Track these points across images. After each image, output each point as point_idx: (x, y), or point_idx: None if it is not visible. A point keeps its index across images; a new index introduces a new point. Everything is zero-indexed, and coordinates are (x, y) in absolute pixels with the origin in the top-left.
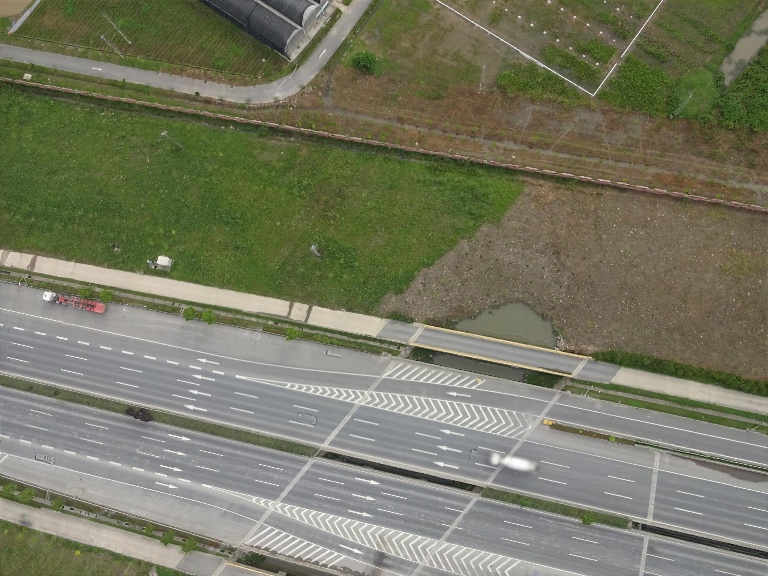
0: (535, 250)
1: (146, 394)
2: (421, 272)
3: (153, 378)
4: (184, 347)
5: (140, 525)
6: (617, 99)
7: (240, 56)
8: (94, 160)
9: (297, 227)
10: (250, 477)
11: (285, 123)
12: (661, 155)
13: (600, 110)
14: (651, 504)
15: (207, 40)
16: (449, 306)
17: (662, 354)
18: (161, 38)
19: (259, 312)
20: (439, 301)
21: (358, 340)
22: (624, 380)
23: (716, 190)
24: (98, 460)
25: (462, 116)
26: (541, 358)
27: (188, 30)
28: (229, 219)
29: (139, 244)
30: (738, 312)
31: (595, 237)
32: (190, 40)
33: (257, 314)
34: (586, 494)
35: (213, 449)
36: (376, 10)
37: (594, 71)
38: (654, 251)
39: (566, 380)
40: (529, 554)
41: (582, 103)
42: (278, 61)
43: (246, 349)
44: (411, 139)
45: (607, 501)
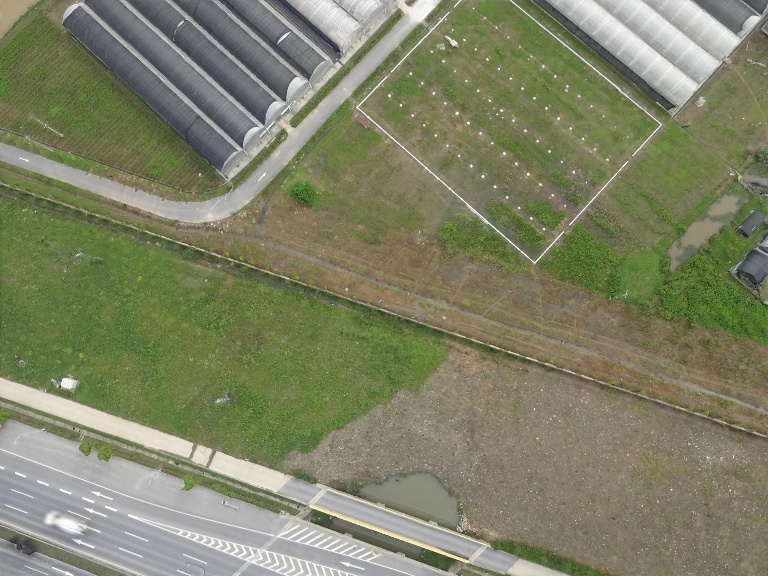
0: (450, 425)
1: (34, 521)
2: (330, 433)
3: (43, 505)
4: (79, 477)
5: None
6: (558, 271)
7: (176, 167)
8: (8, 264)
9: (210, 366)
10: None
11: (212, 250)
12: (594, 337)
13: (539, 280)
14: None
15: (144, 144)
16: (355, 469)
17: (562, 551)
18: (95, 135)
19: (161, 450)
20: (345, 464)
21: (258, 493)
22: (520, 572)
23: (644, 382)
24: None
25: (397, 266)
26: (440, 538)
27: (125, 130)
28: (141, 348)
29: (45, 360)
30: (644, 518)
31: (512, 420)
32: (126, 141)
33: (158, 452)
34: None
35: None
36: (324, 137)
37: (539, 237)
38: (570, 443)
39: (463, 563)
40: None
41: (522, 270)
42: (215, 178)
43: (142, 487)
44: (341, 283)
45: None
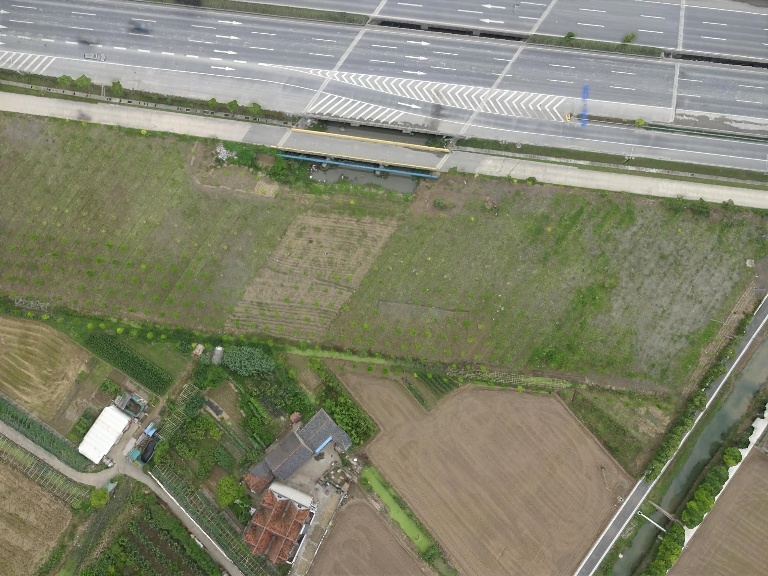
0: None
1: None
2: None
3: None
4: None
5: (201, 108)
6: None
7: None
8: None
9: None
10: (305, 51)
11: None
12: None
13: None
14: (680, 36)
15: None
16: None
17: None
18: None
19: None
20: None
21: None
22: None
23: None
24: (150, 52)
25: None
26: None
27: None
28: None
29: None
30: None
31: None
32: None
33: None
34: (622, 33)
35: (265, 30)
36: None
37: None
38: None
39: None
40: (574, 91)
41: None
42: None
43: None
44: None
45: (641, 37)
